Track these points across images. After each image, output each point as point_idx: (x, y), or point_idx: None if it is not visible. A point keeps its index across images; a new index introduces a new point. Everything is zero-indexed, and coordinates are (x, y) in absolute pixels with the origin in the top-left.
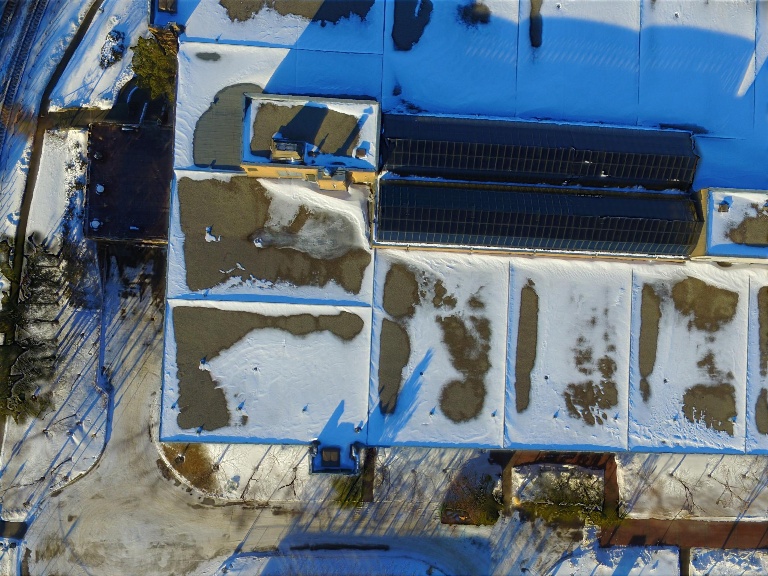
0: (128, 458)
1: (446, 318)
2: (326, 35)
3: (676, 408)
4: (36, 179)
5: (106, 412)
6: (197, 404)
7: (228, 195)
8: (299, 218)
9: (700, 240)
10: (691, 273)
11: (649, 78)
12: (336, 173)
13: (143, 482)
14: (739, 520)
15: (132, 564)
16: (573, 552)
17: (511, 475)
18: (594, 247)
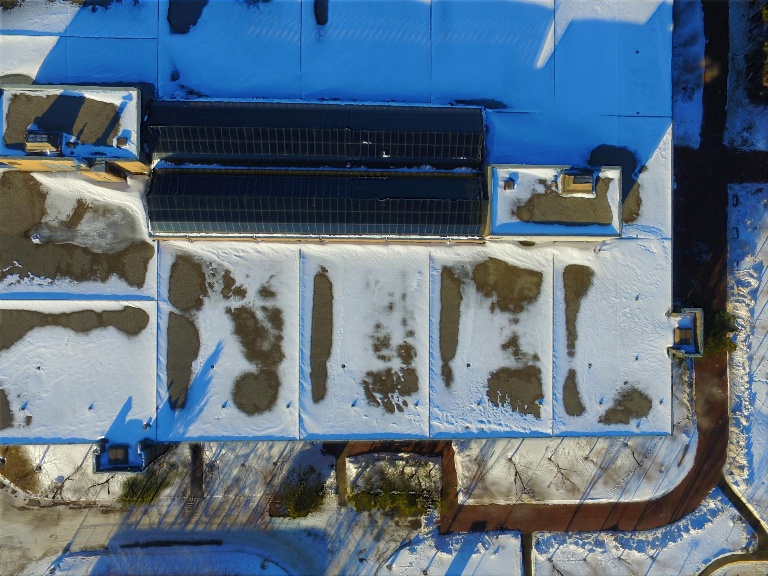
0: None
1: (236, 309)
2: (97, 21)
3: (480, 392)
4: None
5: None
6: None
7: (1, 191)
8: (78, 212)
9: (487, 219)
10: (492, 254)
11: (442, 53)
12: (95, 164)
13: None
14: (582, 502)
15: None
16: (412, 540)
17: (345, 465)
18: (381, 231)
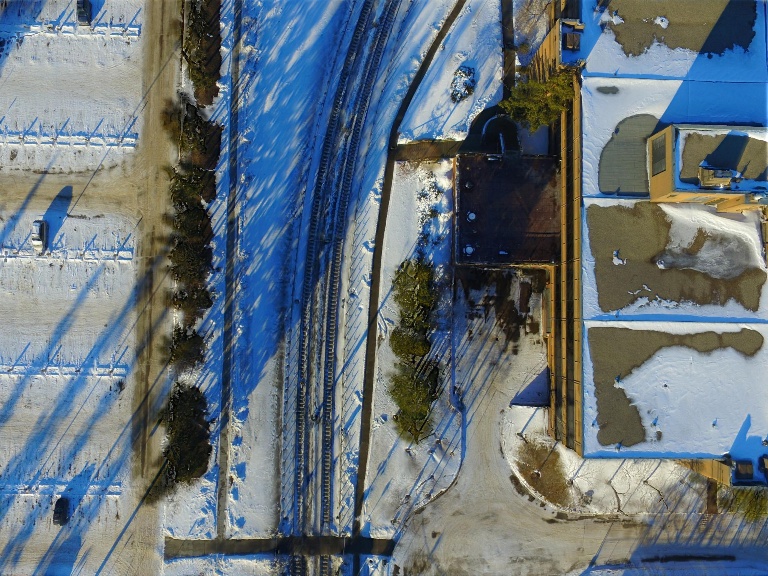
0: (483, 475)
1: None
2: (714, 66)
3: None
4: (388, 208)
5: (461, 430)
6: (615, 421)
7: (632, 220)
8: (697, 240)
9: None
10: None
11: None
12: None
13: (499, 498)
14: None
15: None
16: None
17: None
18: None
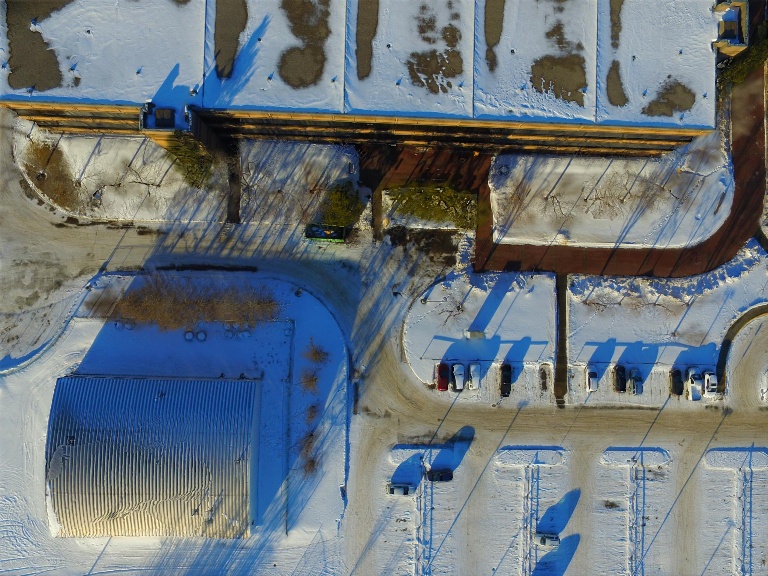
0: None
1: None
2: None
3: (524, 78)
4: None
5: None
6: (28, 64)
7: None
8: None
9: None
10: None
11: None
12: None
13: (6, 201)
14: (618, 247)
15: None
16: (446, 276)
17: (381, 198)
18: None
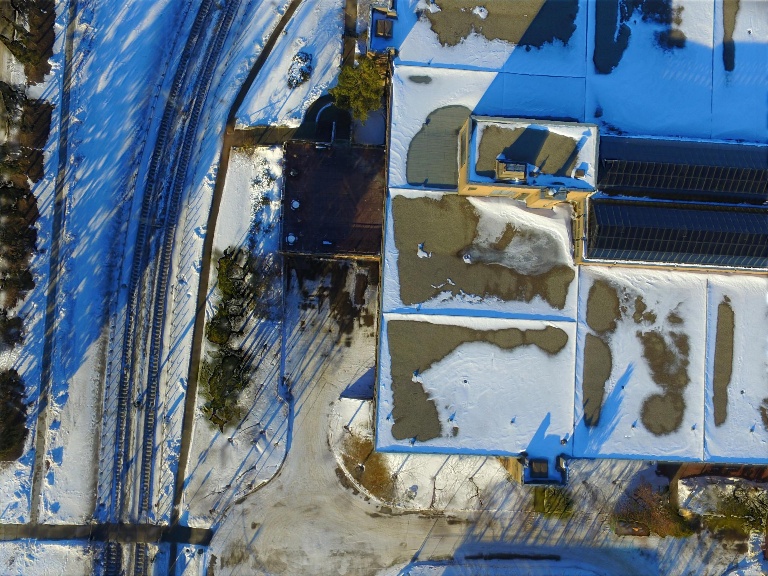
0: (308, 467)
1: (646, 333)
2: (531, 59)
3: None
4: (222, 194)
5: (287, 421)
6: (410, 415)
7: (439, 213)
8: (506, 235)
9: None
10: None
11: None
12: (558, 193)
13: (323, 490)
14: None
15: (313, 571)
16: (739, 564)
17: (678, 487)
18: None
